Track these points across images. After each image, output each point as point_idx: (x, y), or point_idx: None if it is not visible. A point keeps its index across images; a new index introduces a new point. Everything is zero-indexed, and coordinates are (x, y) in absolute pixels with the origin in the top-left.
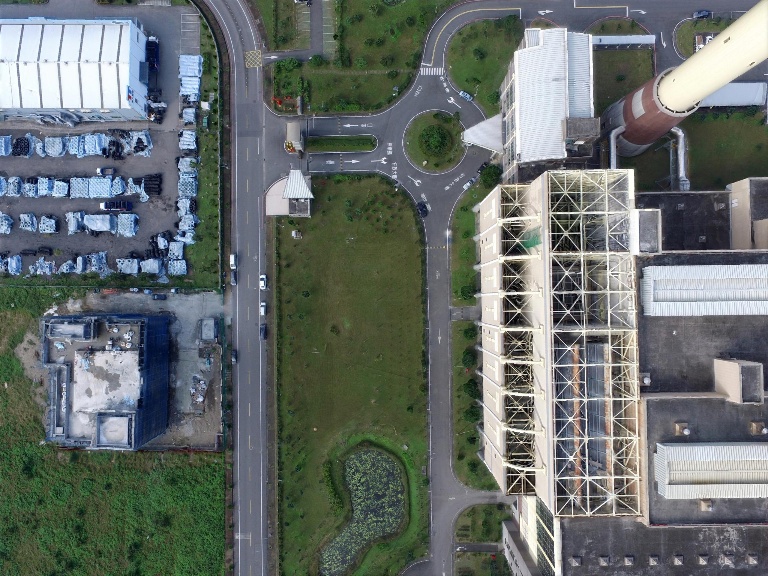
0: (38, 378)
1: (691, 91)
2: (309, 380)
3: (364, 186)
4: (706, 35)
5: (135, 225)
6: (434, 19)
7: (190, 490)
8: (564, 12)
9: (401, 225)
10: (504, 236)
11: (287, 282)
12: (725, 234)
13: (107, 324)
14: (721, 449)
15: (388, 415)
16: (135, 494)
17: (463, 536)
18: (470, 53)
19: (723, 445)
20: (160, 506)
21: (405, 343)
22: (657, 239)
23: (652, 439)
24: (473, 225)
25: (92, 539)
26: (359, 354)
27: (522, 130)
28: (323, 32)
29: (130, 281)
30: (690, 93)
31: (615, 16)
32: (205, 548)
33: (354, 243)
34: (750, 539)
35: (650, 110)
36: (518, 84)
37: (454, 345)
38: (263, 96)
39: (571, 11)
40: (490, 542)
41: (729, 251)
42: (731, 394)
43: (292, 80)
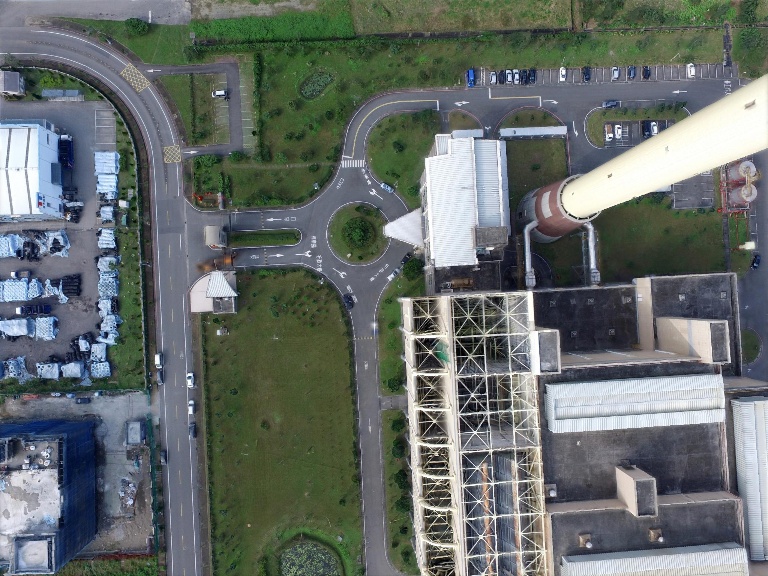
0: None
1: (588, 207)
2: (241, 476)
3: (289, 280)
4: (615, 123)
5: (54, 328)
6: (353, 112)
7: None
8: (480, 103)
9: (328, 317)
10: (417, 348)
11: (215, 379)
12: (633, 326)
13: (23, 443)
14: (620, 562)
15: (322, 507)
16: None
17: None
18: (390, 145)
19: (622, 558)
20: None
21: (336, 435)
22: (557, 358)
23: (558, 551)
24: (399, 315)
25: None
26: (291, 448)
27: (435, 236)
28: (242, 126)
29: (51, 386)
30: (587, 208)
31: (529, 106)
32: None
33: (281, 337)
34: None
35: (556, 214)
36: (430, 190)
37: (384, 434)
38: (184, 191)
39: (487, 102)
40: None
41: (626, 364)
42: (629, 505)
43: (213, 175)
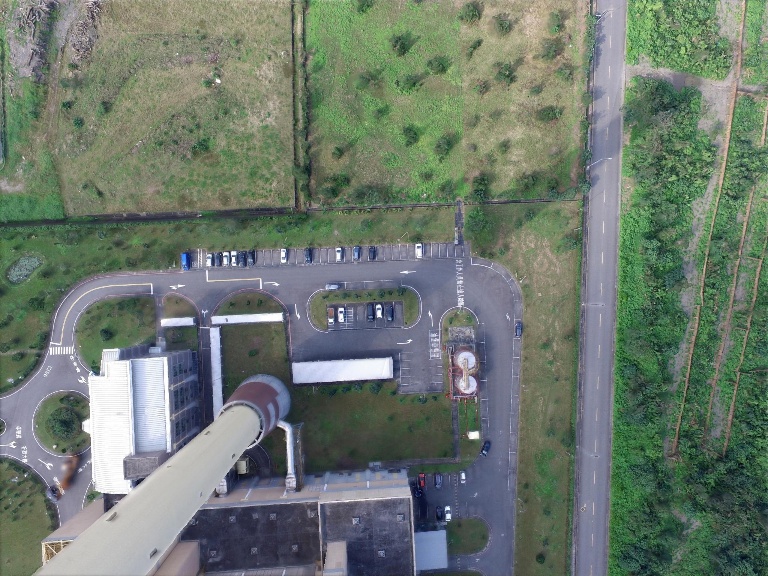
0: None
1: None
2: None
3: None
4: (339, 306)
5: None
6: (62, 297)
7: None
8: (197, 286)
9: (33, 510)
10: None
11: None
12: (318, 541)
13: None
14: None
15: None
16: None
17: None
18: None
19: None
20: None
21: None
22: None
23: None
24: None
25: None
26: None
27: (95, 459)
28: None
29: None
30: None
31: (249, 288)
32: None
33: None
34: None
35: None
36: (91, 411)
37: None
38: None
39: (204, 285)
40: None
41: None
42: None
43: None
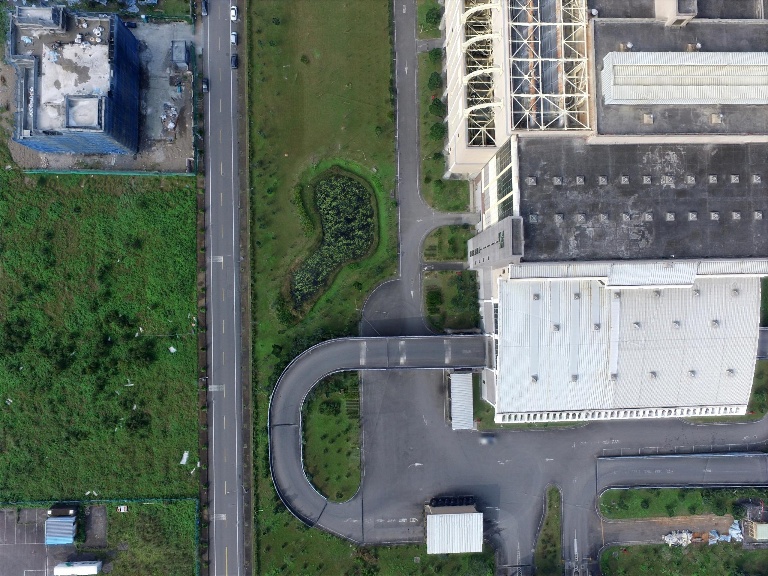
0: (4, 103)
1: None
2: (280, 108)
3: None
4: None
5: None
6: None
7: (161, 213)
8: None
9: None
10: None
11: (258, 14)
12: None
13: (76, 17)
14: (660, 54)
15: (357, 141)
16: (105, 218)
17: (430, 255)
18: None
19: None
20: (131, 229)
21: (373, 73)
22: None
23: (599, 60)
24: None
25: (61, 262)
26: (329, 83)
27: None
28: None
29: (99, 8)
30: None
31: None
32: (177, 270)
33: None
34: (688, 162)
35: None
36: None
37: (420, 75)
38: None
39: None
40: (456, 261)
41: None
42: (669, 14)
43: None
